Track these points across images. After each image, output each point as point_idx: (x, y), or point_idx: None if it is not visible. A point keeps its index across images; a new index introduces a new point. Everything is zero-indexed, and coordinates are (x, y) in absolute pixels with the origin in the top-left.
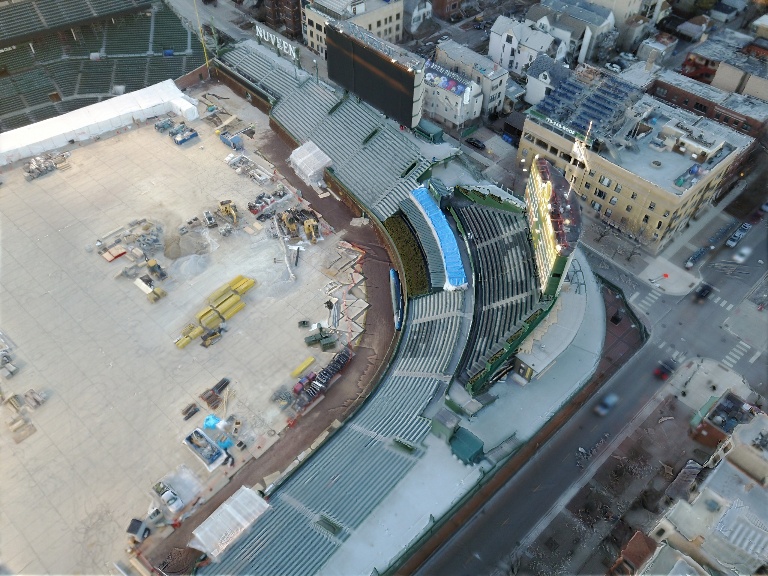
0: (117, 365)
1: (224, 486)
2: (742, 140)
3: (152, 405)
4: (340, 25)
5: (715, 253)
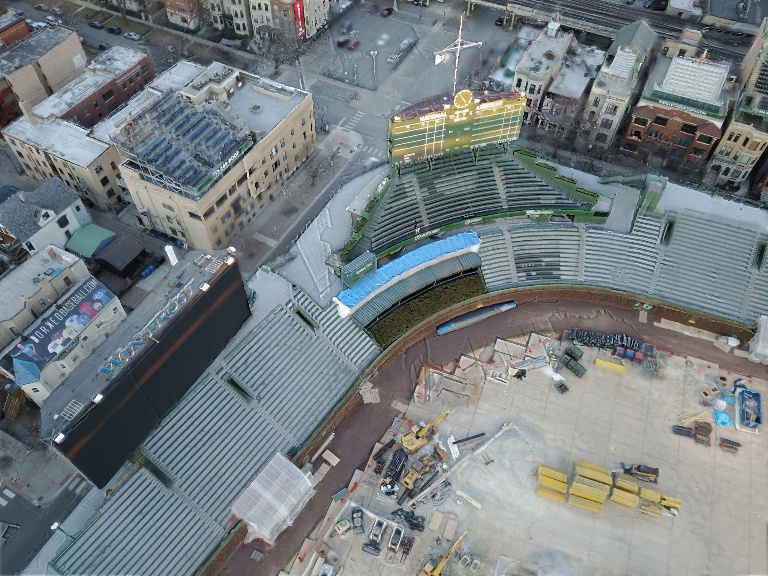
0: (750, 567)
1: (759, 378)
2: (184, 67)
3: (754, 489)
4: (67, 410)
5: None
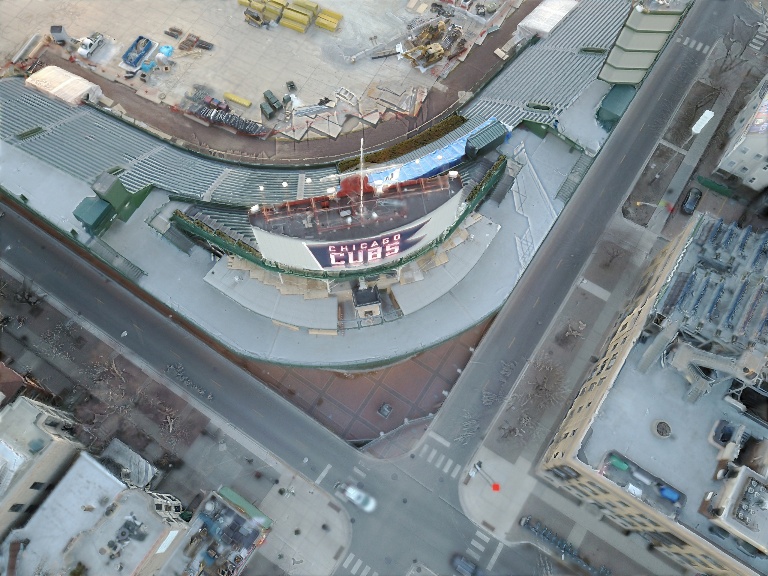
0: None
1: (108, 79)
2: None
3: (176, 6)
4: None
5: (577, 575)
